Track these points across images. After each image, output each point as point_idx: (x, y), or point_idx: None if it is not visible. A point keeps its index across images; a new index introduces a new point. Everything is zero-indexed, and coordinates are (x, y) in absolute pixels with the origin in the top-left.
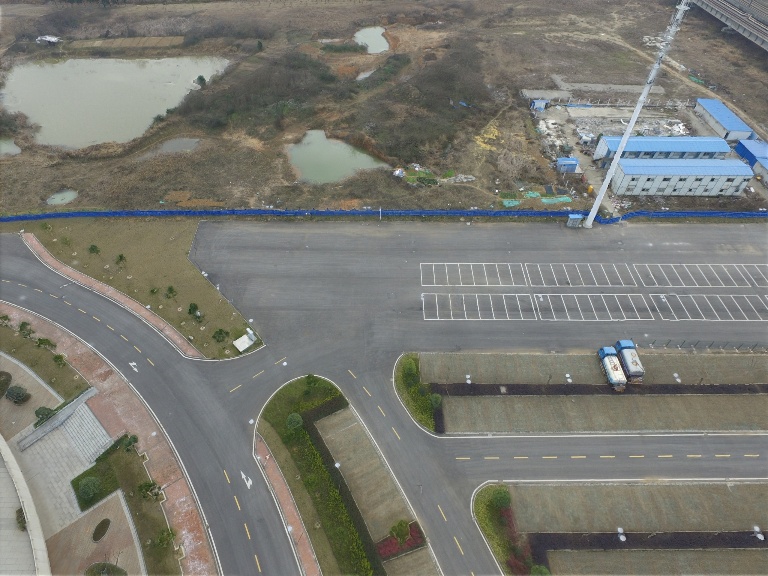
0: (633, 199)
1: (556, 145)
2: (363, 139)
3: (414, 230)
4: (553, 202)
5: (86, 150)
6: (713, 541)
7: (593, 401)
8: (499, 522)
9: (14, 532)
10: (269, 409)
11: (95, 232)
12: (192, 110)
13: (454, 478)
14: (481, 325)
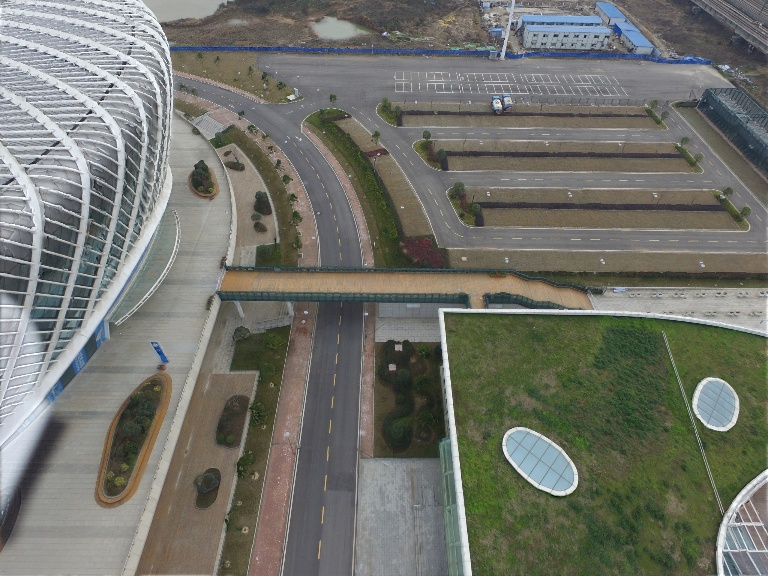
0: (536, 50)
1: (493, 25)
2: (362, 18)
3: (393, 59)
4: (483, 49)
5: (176, 21)
6: (528, 153)
7: (484, 118)
8: (425, 148)
9: (193, 135)
10: (309, 118)
11: (194, 57)
12: (244, 2)
13: (405, 138)
14: (428, 94)
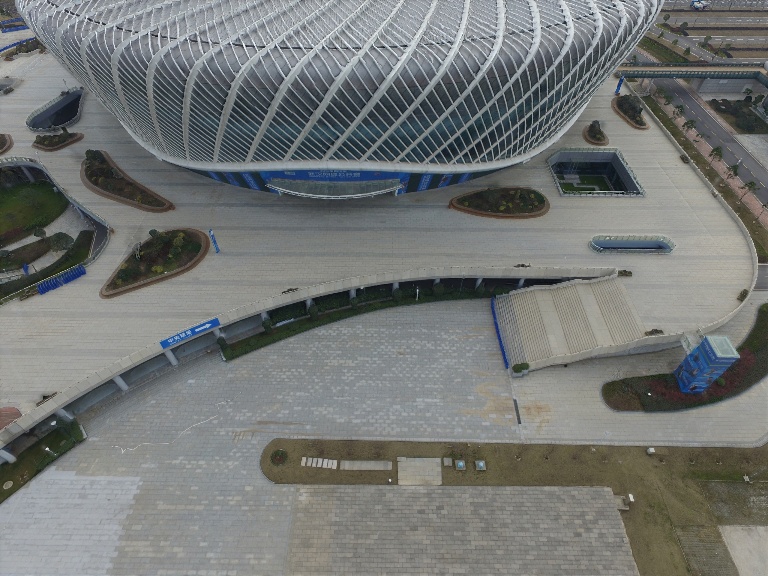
0: None
1: None
2: None
3: None
4: None
5: None
6: (736, 28)
7: None
8: None
9: None
10: None
11: None
12: None
13: None
14: None
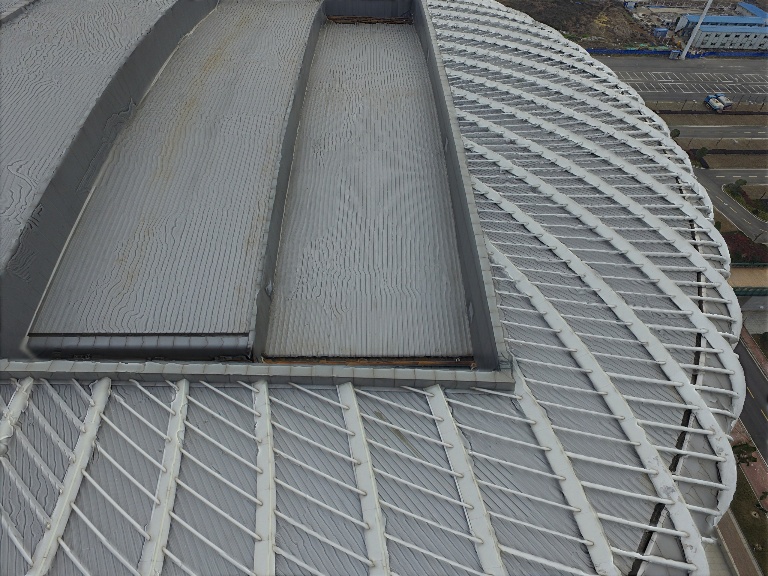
0: (705, 50)
1: (649, 25)
2: None
3: None
4: (657, 49)
5: None
6: None
7: (706, 116)
8: None
9: None
10: None
11: None
12: None
13: None
14: None
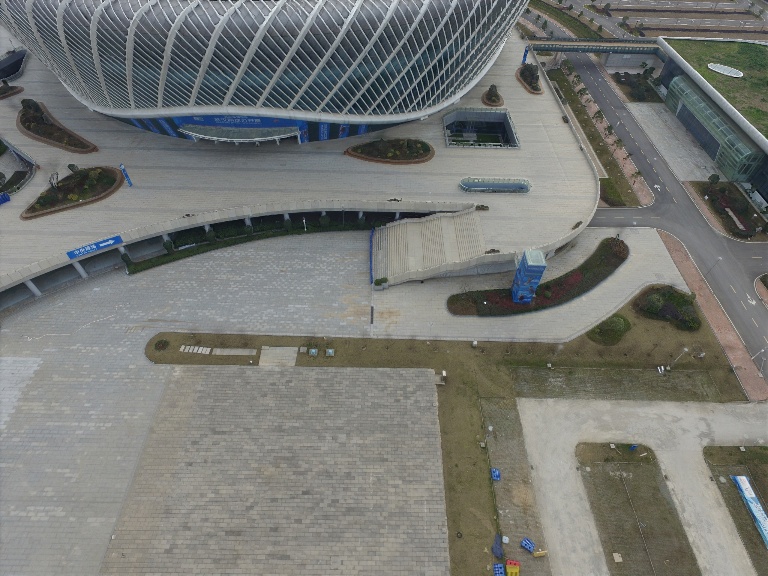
0: None
1: None
2: None
3: None
4: None
5: None
6: (657, 10)
7: None
8: None
9: None
10: None
11: None
12: None
13: None
14: None
